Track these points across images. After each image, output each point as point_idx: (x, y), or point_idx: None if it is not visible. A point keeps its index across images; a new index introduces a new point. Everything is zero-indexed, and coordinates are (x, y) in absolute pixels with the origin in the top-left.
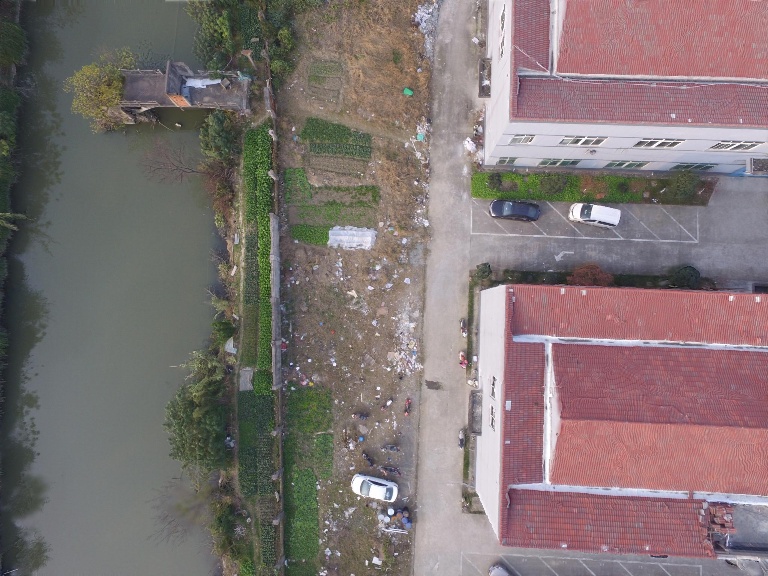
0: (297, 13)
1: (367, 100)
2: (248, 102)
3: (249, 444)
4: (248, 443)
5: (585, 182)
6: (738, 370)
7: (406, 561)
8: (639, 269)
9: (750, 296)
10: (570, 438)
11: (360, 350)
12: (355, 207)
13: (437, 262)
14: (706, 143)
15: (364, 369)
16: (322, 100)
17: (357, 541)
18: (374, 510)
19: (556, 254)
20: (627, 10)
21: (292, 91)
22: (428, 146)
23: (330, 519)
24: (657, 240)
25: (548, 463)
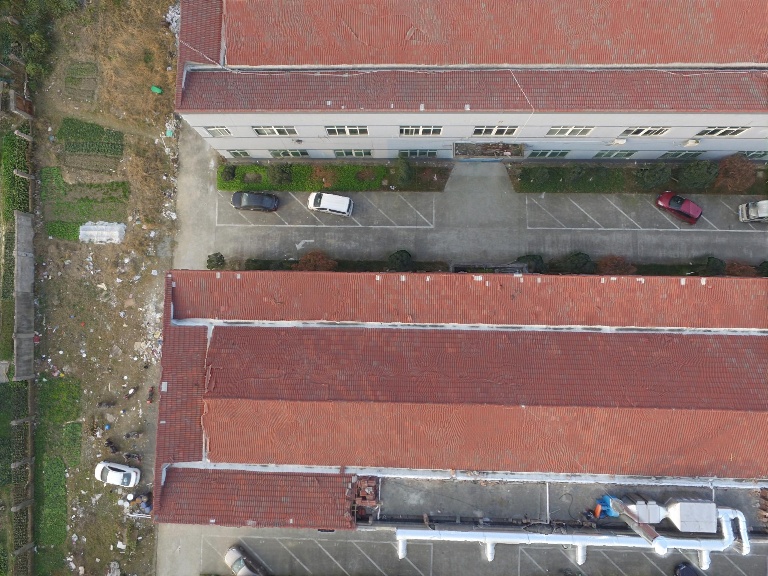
0: (55, 18)
1: (118, 99)
2: (4, 105)
3: (4, 435)
4: (3, 434)
5: (325, 172)
6: (385, 347)
7: (149, 545)
8: (376, 255)
9: (395, 275)
10: (215, 416)
11: (108, 341)
12: (106, 203)
13: (183, 254)
14: (389, 129)
15: (112, 359)
16: (78, 100)
17: (102, 526)
18: (119, 496)
19: (297, 243)
20: (289, 3)
21: (49, 93)
22: (177, 142)
23: (77, 506)
24: (393, 226)
25: (208, 442)
